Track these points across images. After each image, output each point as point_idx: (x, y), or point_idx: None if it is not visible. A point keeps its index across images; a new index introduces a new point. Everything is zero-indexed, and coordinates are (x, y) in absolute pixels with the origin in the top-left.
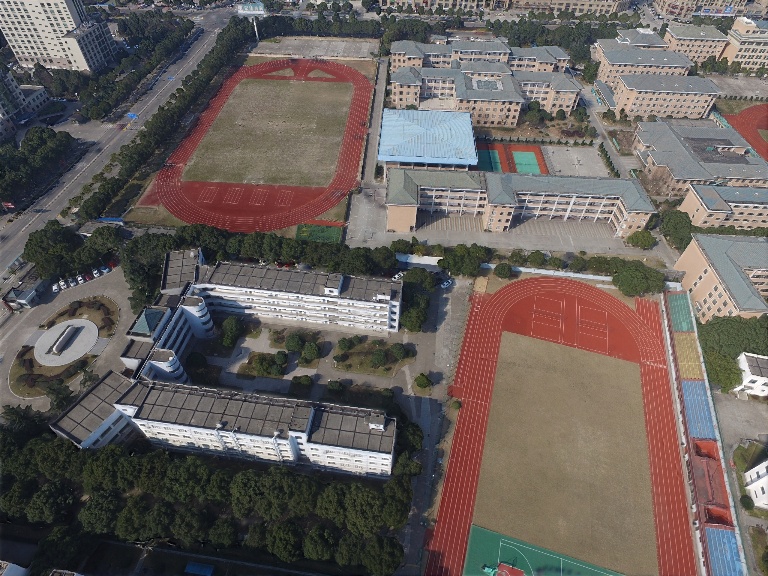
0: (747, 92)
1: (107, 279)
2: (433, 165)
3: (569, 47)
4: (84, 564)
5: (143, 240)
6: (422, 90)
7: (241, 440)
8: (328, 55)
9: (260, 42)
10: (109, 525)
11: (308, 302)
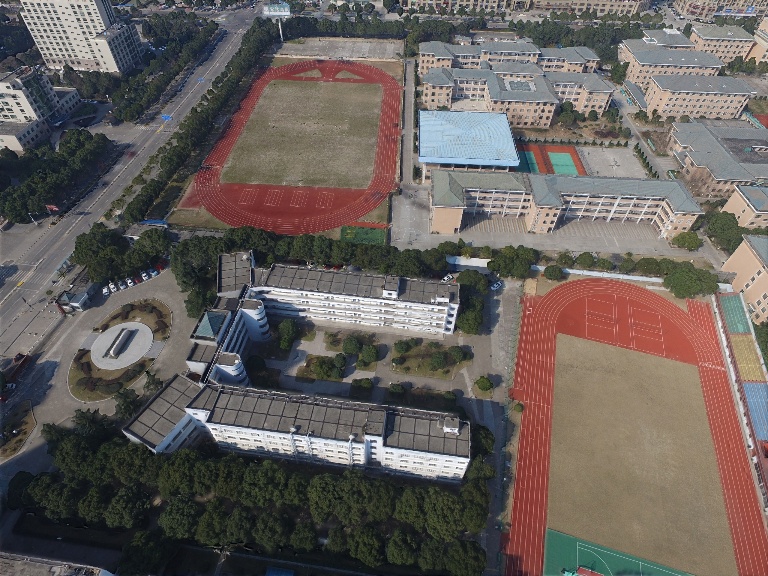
0: None
1: (156, 282)
2: (473, 166)
3: (594, 47)
4: (163, 569)
5: (194, 243)
6: (453, 91)
7: (314, 444)
8: (354, 56)
9: (284, 43)
10: (190, 530)
11: (365, 305)
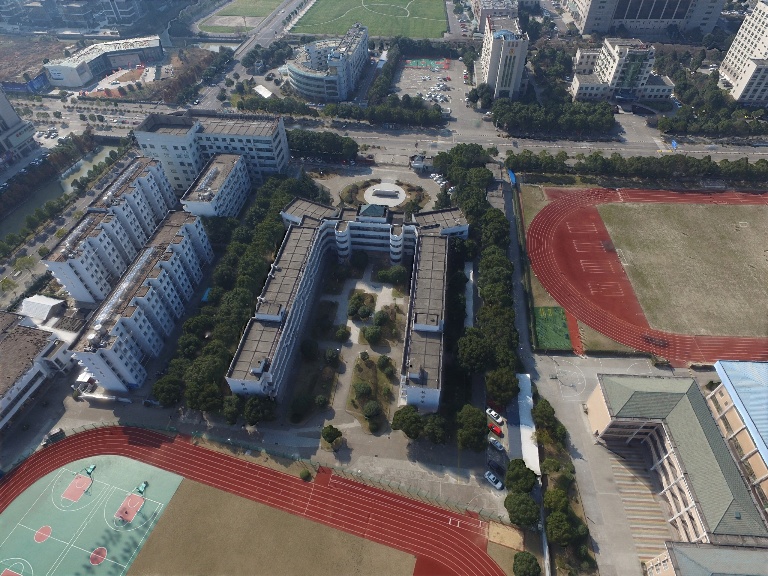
0: None
1: None
2: None
3: None
4: None
5: None
6: None
7: None
8: None
9: None
10: None
11: None
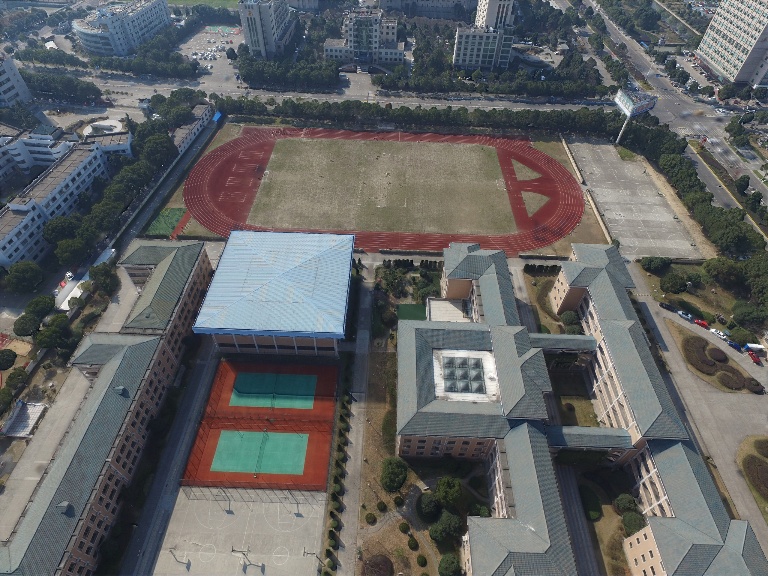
0: None
1: None
2: None
3: None
4: None
5: None
6: None
7: None
8: (606, 205)
9: (613, 145)
10: None
11: None
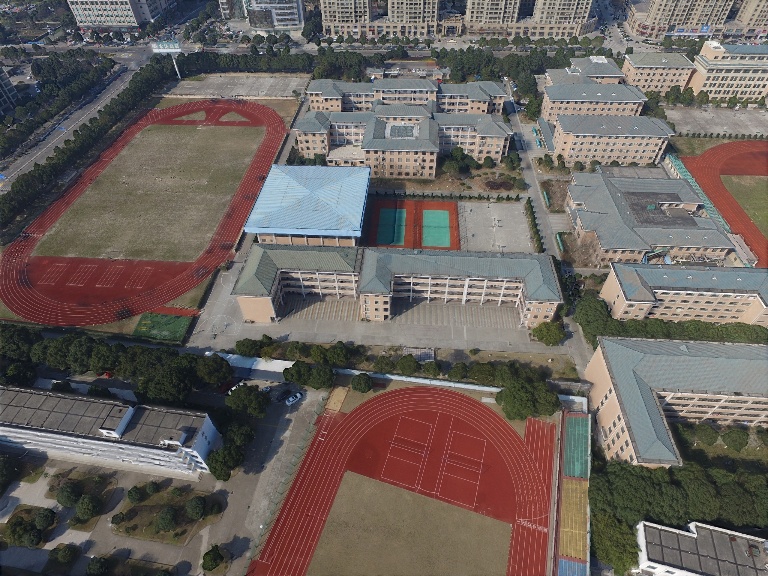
0: (714, 127)
1: None
2: (313, 236)
3: (518, 77)
4: None
5: None
6: (333, 137)
7: None
8: (250, 94)
9: (182, 81)
10: None
11: (87, 443)
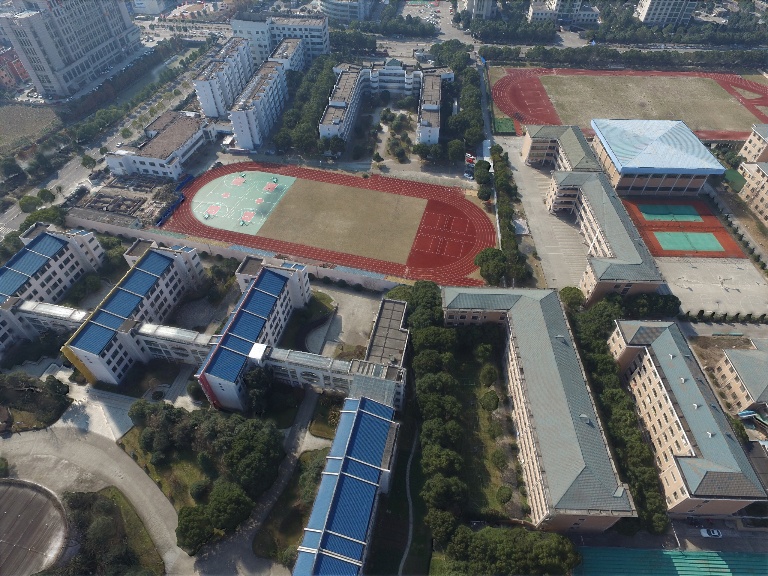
0: None
1: None
2: None
3: None
4: None
5: None
6: None
7: None
8: None
9: None
10: None
11: None
